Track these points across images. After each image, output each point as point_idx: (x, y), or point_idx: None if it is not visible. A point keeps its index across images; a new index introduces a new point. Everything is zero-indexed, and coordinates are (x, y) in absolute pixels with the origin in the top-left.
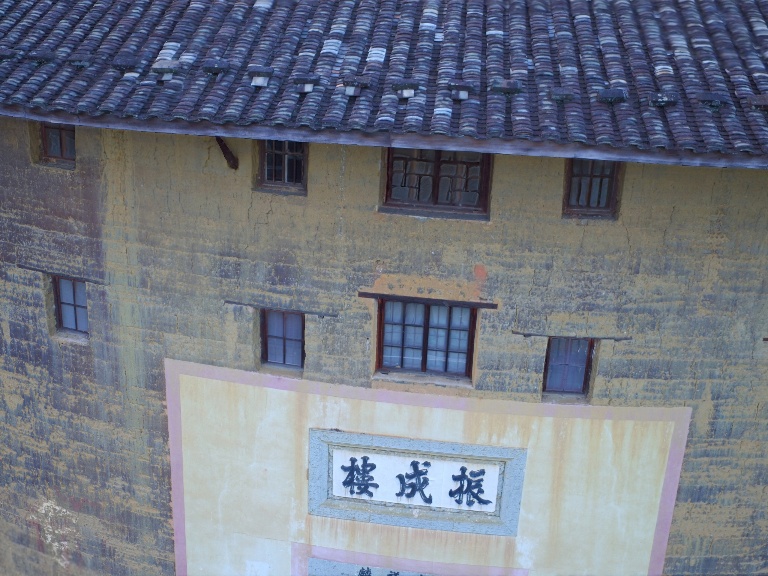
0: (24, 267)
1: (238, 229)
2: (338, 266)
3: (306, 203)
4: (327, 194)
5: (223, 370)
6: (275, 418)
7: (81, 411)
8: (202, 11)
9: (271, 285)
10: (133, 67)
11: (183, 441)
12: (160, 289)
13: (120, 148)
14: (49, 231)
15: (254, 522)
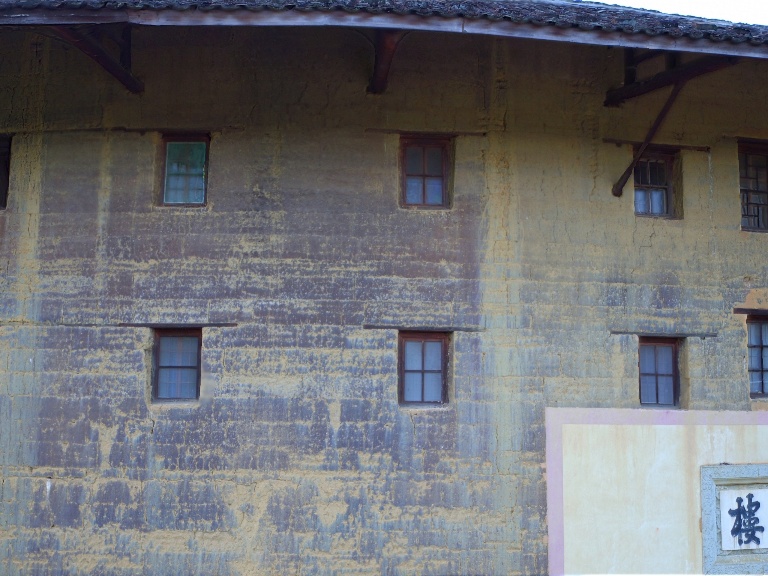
0: (373, 327)
1: (624, 253)
2: (715, 284)
3: (683, 225)
4: (701, 215)
5: (610, 411)
6: (665, 461)
7: (434, 500)
8: None
9: (656, 309)
10: None
11: (565, 511)
12: (543, 327)
13: (505, 182)
14: (414, 279)
15: None
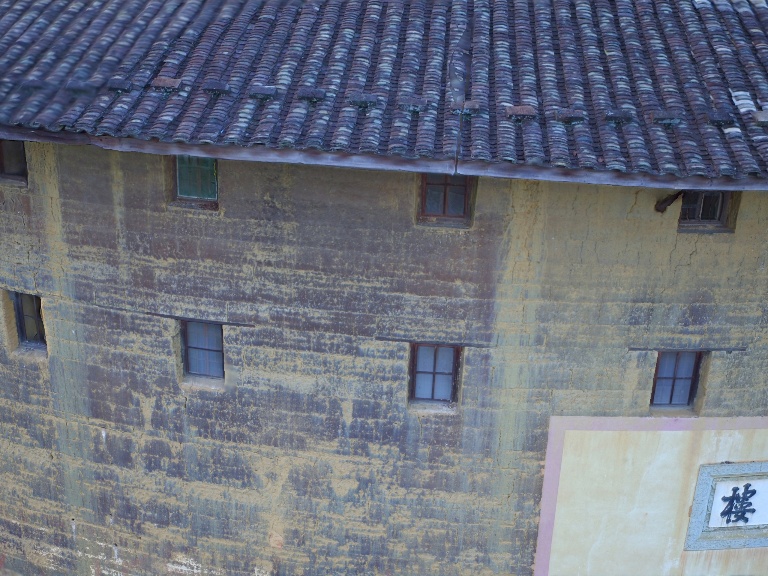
0: (385, 339)
1: (657, 273)
2: (755, 299)
3: (732, 240)
4: (755, 229)
5: (616, 420)
6: (665, 460)
7: (436, 485)
8: (733, 55)
9: (683, 327)
10: (733, 122)
11: (558, 499)
12: (557, 345)
13: (533, 201)
14: (427, 297)
15: (625, 569)
